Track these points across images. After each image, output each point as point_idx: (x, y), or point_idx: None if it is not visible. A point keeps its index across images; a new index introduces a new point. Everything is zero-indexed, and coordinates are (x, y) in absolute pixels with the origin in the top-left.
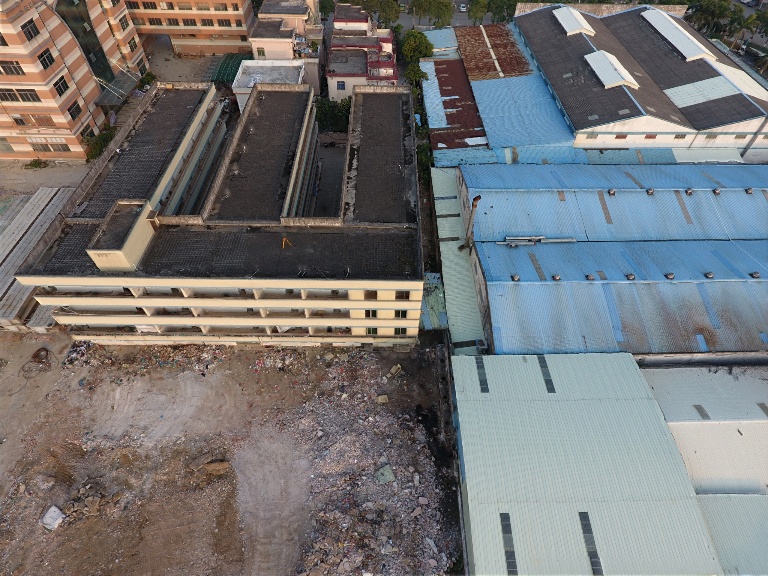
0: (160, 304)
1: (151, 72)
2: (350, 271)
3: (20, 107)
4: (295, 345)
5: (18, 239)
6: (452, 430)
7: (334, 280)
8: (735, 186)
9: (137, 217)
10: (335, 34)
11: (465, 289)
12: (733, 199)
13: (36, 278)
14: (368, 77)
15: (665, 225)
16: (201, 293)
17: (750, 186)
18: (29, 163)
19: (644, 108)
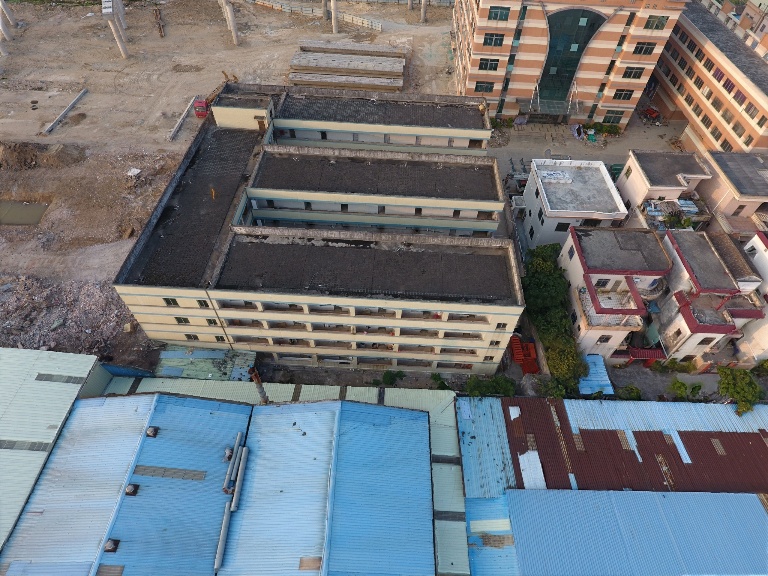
0: None
1: (620, 128)
2: (164, 238)
3: None
4: None
5: None
6: None
7: None
8: None
9: (246, 107)
10: (718, 237)
11: None
12: None
13: None
14: (585, 274)
15: None
16: None
17: None
18: None
19: None
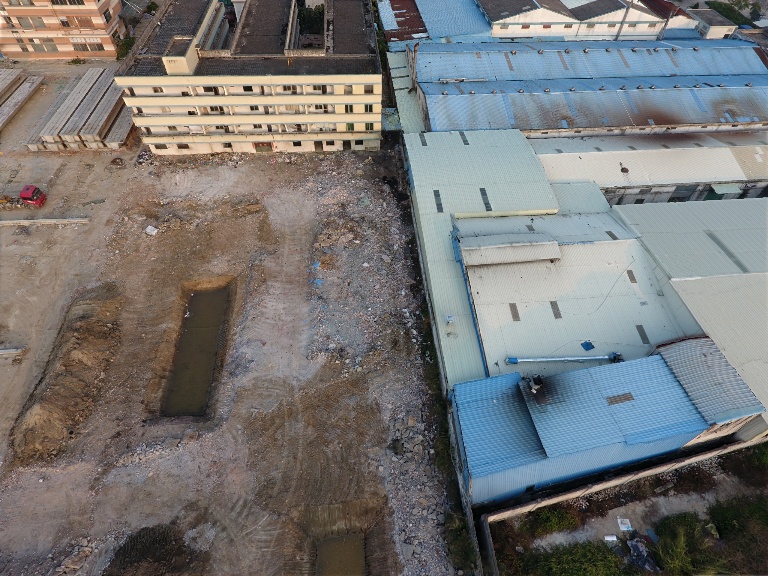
0: (208, 103)
1: (154, 2)
2: None
3: (67, 10)
4: (297, 151)
5: (84, 96)
6: (406, 175)
7: (324, 75)
8: (599, 48)
9: (190, 43)
10: None
11: (413, 112)
12: (597, 55)
13: (128, 78)
14: None
15: (549, 70)
16: (236, 94)
17: (610, 48)
18: (70, 61)
19: (540, 4)
